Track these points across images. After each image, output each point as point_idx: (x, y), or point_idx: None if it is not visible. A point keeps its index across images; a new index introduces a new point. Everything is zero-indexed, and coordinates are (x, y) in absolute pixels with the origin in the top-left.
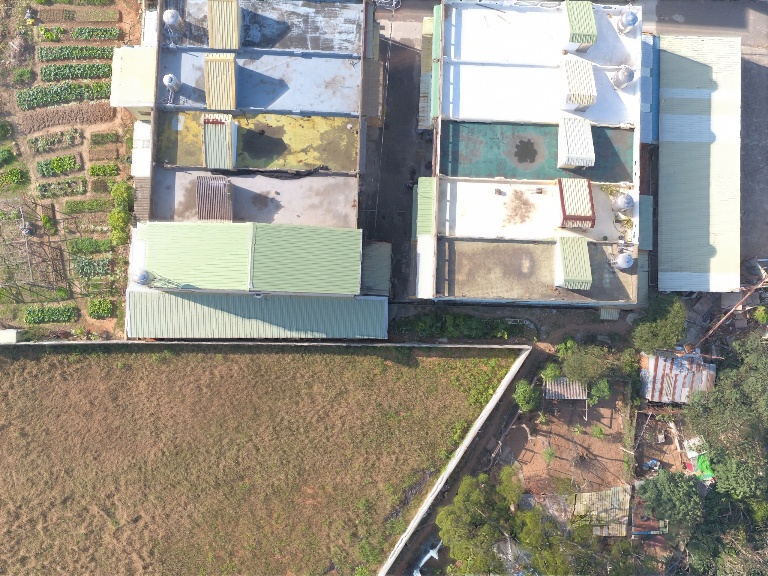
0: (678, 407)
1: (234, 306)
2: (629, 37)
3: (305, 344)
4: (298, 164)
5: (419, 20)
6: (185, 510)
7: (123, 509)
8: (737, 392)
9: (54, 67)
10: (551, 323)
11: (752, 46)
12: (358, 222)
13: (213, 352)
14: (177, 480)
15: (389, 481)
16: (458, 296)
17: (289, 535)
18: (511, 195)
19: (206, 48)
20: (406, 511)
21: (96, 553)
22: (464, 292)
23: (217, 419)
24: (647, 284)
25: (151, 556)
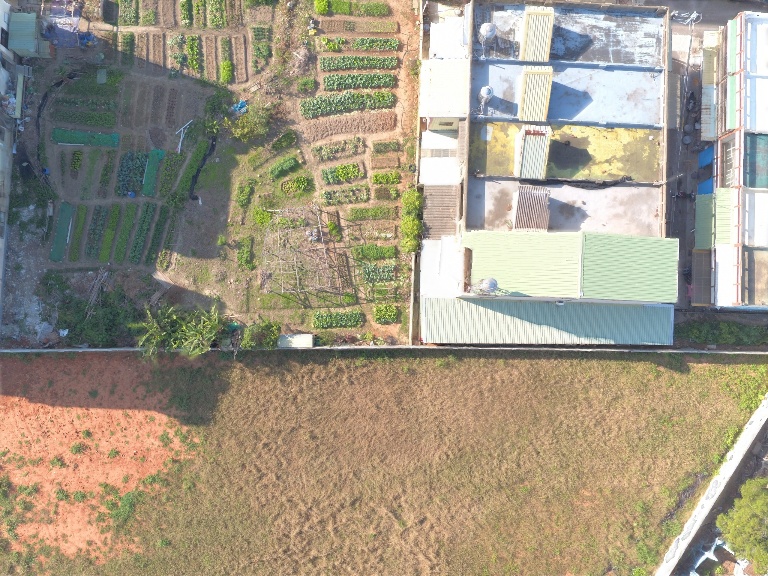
0: None
1: (526, 312)
2: None
3: (589, 350)
4: (603, 174)
5: (683, 33)
6: (469, 512)
7: (409, 511)
8: None
9: (337, 77)
10: None
11: None
12: None
13: (494, 357)
14: (461, 482)
15: (664, 484)
16: (758, 304)
17: (569, 537)
18: None
19: (514, 60)
20: (680, 514)
21: (384, 554)
22: (763, 300)
23: (499, 423)
24: None
25: (437, 557)
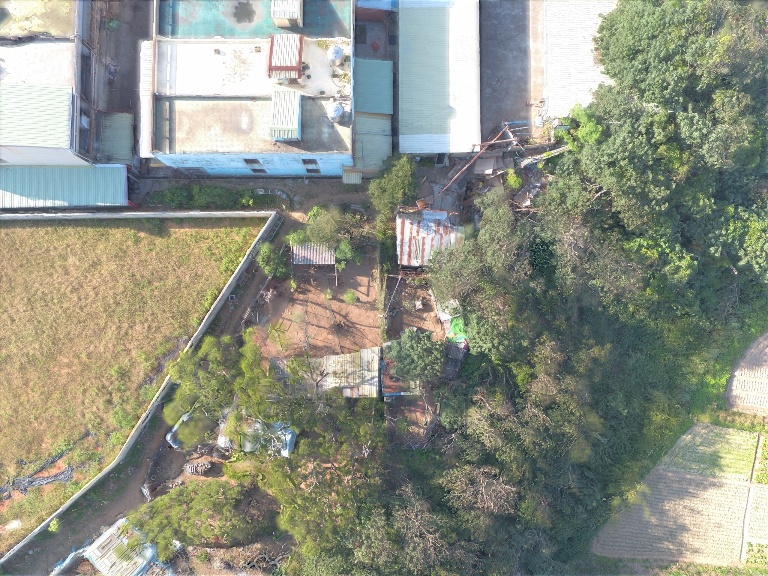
0: (434, 273)
1: None
2: None
3: (52, 215)
4: (23, 32)
5: None
6: None
7: None
8: (470, 245)
9: None
10: (304, 193)
11: None
12: (113, 101)
13: None
14: None
15: (142, 349)
16: (179, 153)
17: (45, 403)
18: (230, 55)
19: None
20: (160, 378)
21: None
22: (185, 149)
23: None
24: (391, 148)
25: None
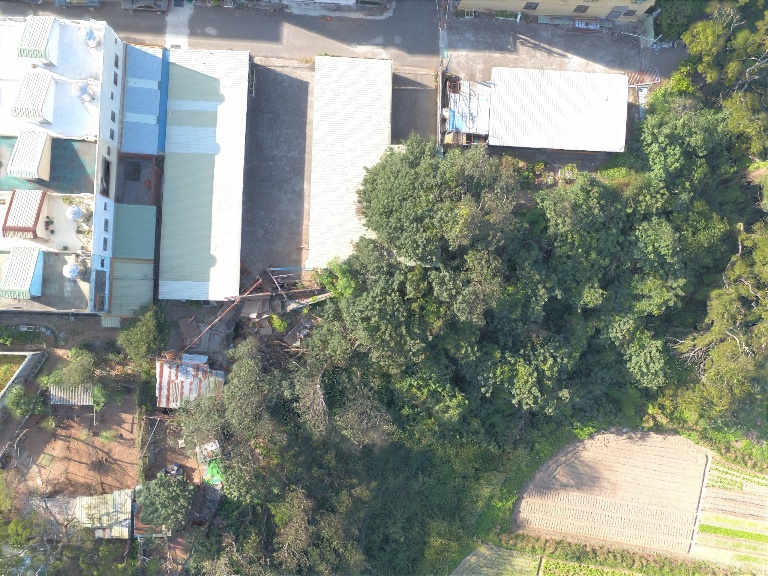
0: None
1: None
2: (100, 51)
3: None
4: None
5: None
6: None
7: None
8: (216, 399)
9: None
10: (69, 330)
11: (285, 58)
12: None
13: None
14: None
15: None
16: None
17: None
18: None
19: None
20: None
21: None
22: None
23: None
24: (152, 292)
25: None
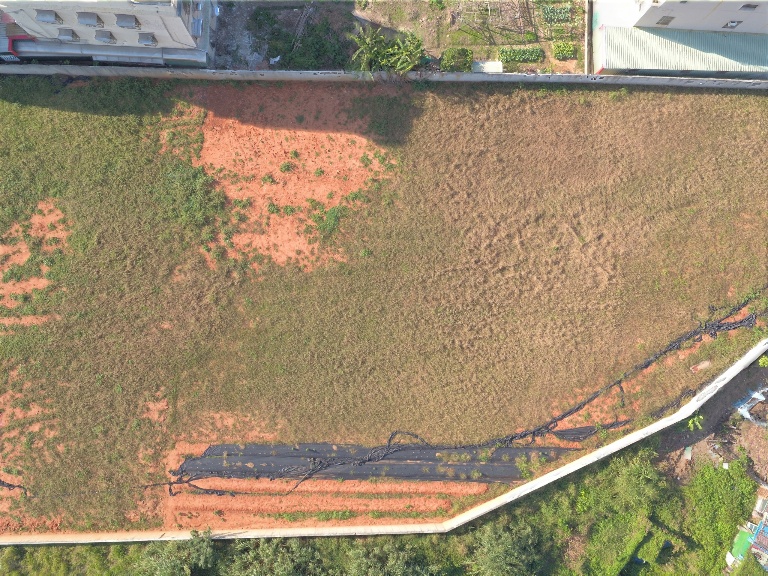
0: None
1: (696, 41)
2: None
3: (750, 81)
4: None
5: None
6: (642, 230)
7: (588, 228)
8: None
9: None
10: None
11: None
12: None
13: (661, 92)
14: (634, 203)
15: None
16: None
17: (732, 255)
18: None
19: None
20: None
21: (566, 266)
22: None
23: (667, 151)
24: None
25: (614, 270)
